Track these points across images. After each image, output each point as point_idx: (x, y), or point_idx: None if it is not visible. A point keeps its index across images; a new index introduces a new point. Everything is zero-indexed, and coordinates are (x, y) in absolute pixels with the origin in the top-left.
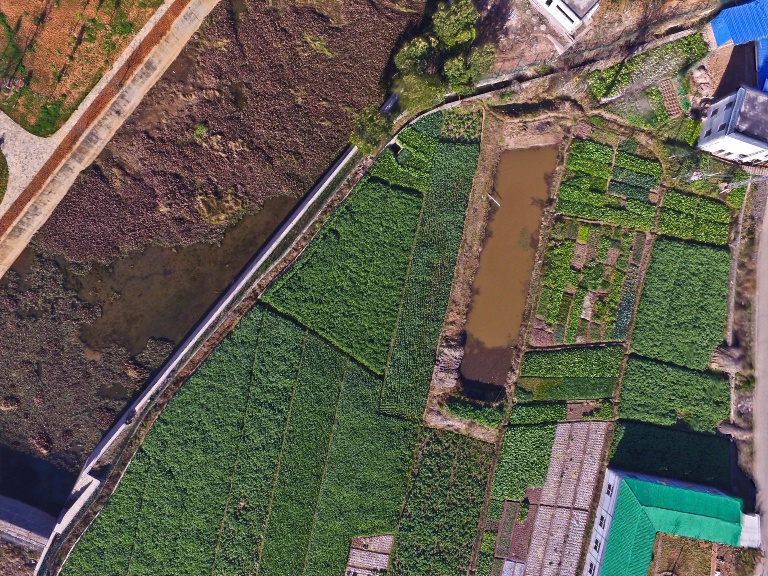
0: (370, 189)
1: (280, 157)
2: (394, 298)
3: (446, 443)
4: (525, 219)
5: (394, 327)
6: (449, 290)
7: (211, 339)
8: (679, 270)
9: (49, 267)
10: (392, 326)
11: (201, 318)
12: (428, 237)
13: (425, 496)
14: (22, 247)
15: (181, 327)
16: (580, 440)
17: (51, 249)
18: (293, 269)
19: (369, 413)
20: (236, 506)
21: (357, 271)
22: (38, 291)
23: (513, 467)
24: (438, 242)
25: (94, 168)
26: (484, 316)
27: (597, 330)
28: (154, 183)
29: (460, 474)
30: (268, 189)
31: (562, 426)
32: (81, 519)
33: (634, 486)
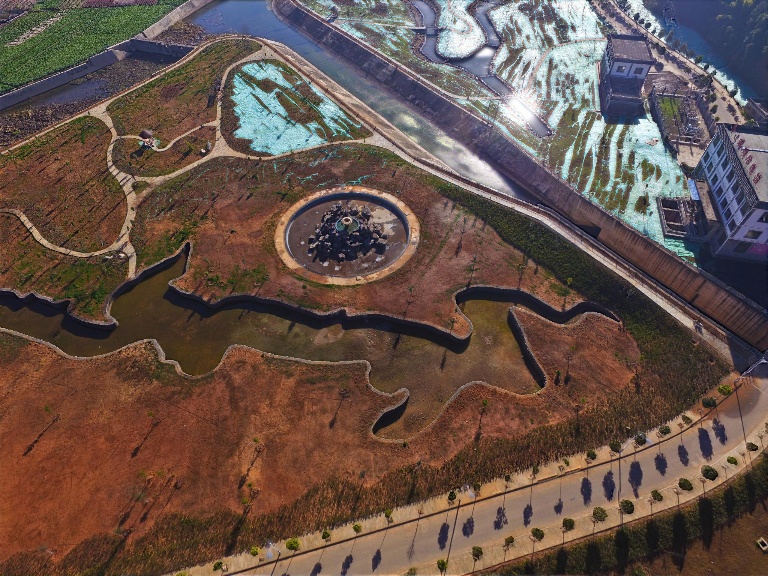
0: None
1: None
2: None
3: None
4: None
5: None
6: None
7: None
8: None
9: None
10: None
11: (52, 89)
12: None
13: None
14: None
15: None
16: None
17: None
18: None
19: None
20: None
21: None
22: None
23: None
24: None
25: None
26: None
27: None
28: None
29: None
30: None
31: None
32: None
33: None
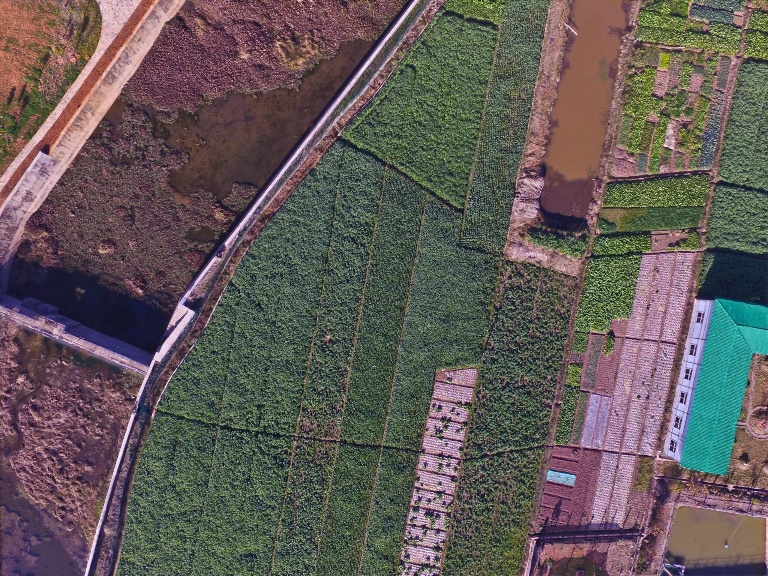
0: (446, 22)
1: (354, 1)
2: (472, 131)
3: (528, 276)
4: (603, 49)
5: (472, 161)
6: (527, 122)
7: (294, 177)
8: (767, 93)
9: (139, 116)
10: (471, 159)
11: (282, 162)
12: (504, 69)
13: (508, 329)
14: (114, 97)
15: (263, 171)
16: (666, 271)
17: (140, 99)
18: (372, 105)
19: (450, 245)
20: (323, 339)
21: (434, 105)
22: (130, 139)
23: (597, 298)
24: (515, 74)
25: (178, 19)
26: (563, 149)
27: (681, 159)
28: (234, 32)
29: (543, 307)
30: (343, 33)
31: (647, 257)
32: (177, 352)
33: (728, 306)
